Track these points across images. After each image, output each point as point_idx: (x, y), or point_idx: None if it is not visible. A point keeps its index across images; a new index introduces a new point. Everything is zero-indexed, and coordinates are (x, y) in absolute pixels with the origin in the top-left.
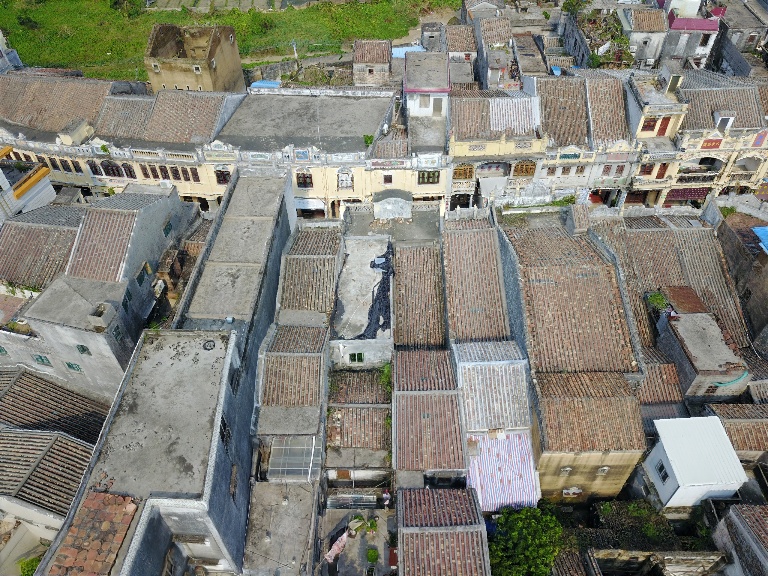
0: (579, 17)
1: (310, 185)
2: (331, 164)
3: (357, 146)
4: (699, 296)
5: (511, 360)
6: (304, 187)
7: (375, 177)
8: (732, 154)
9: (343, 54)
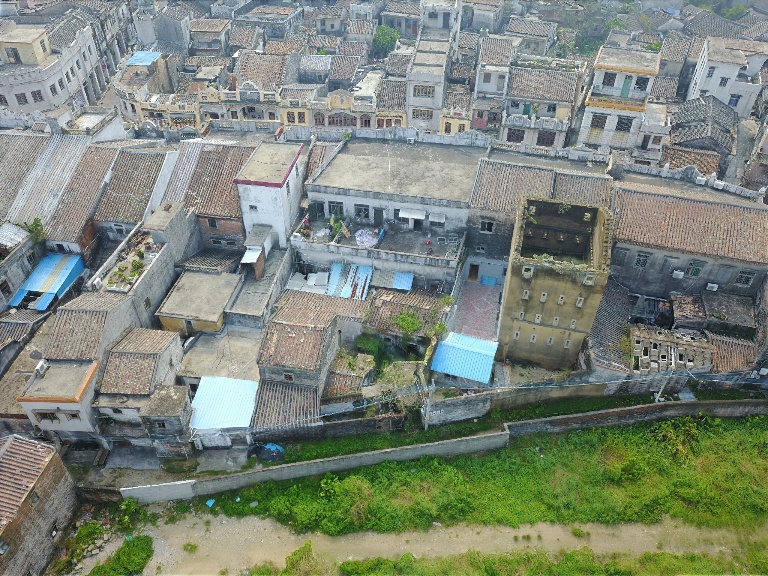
0: None
1: None
2: None
3: (357, 148)
4: None
5: (308, 55)
6: None
7: None
8: None
9: (342, 456)
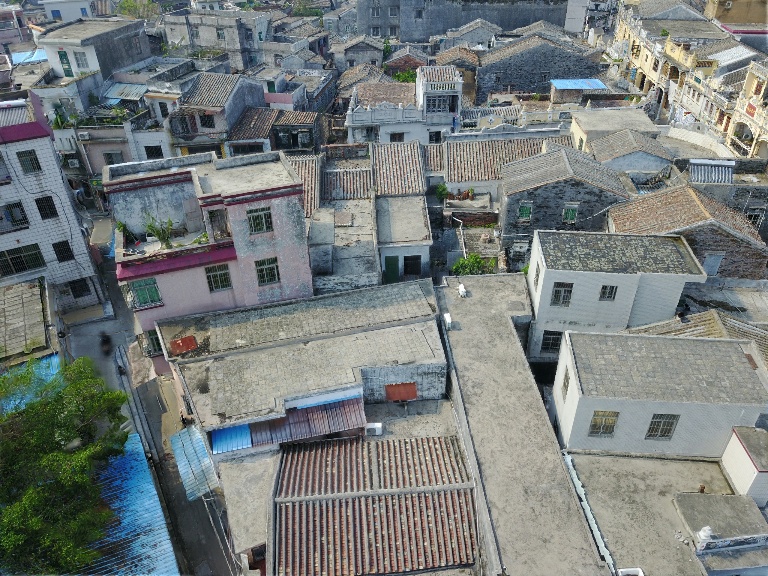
0: None
1: None
2: None
3: None
4: None
5: None
6: None
7: None
8: (757, 130)
9: None
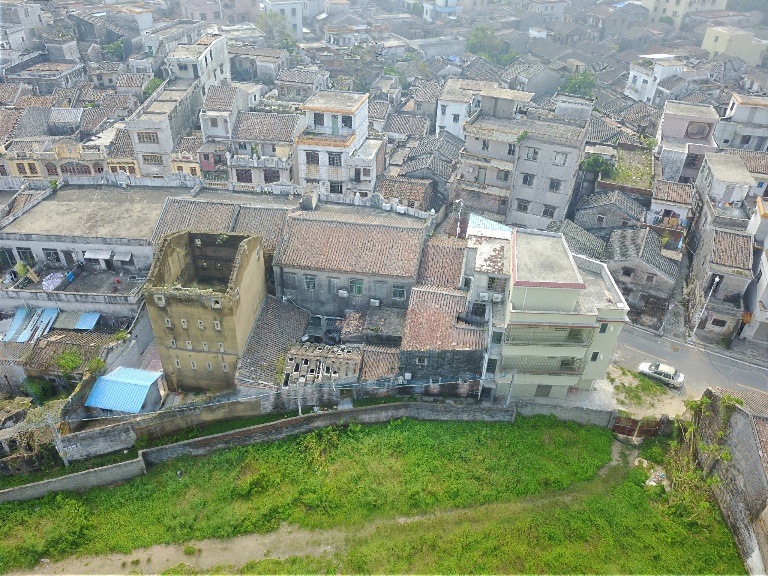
0: None
1: None
2: None
3: (65, 195)
4: None
5: (59, 108)
6: None
7: None
8: None
9: None
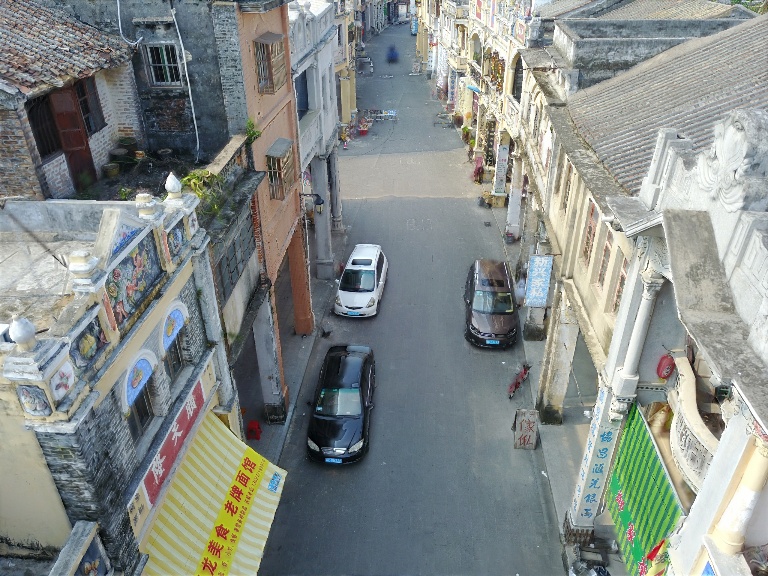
0: None
1: None
2: None
3: None
4: None
5: None
6: None
7: None
8: None
9: None
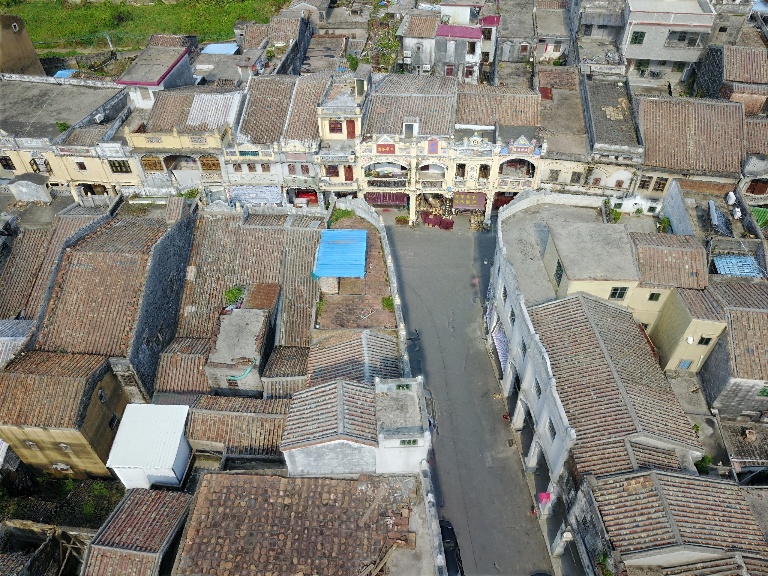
0: (374, 21)
1: (14, 167)
2: (22, 148)
3: (59, 133)
4: (288, 294)
5: (15, 337)
6: (9, 169)
7: (68, 163)
8: (411, 160)
9: None
